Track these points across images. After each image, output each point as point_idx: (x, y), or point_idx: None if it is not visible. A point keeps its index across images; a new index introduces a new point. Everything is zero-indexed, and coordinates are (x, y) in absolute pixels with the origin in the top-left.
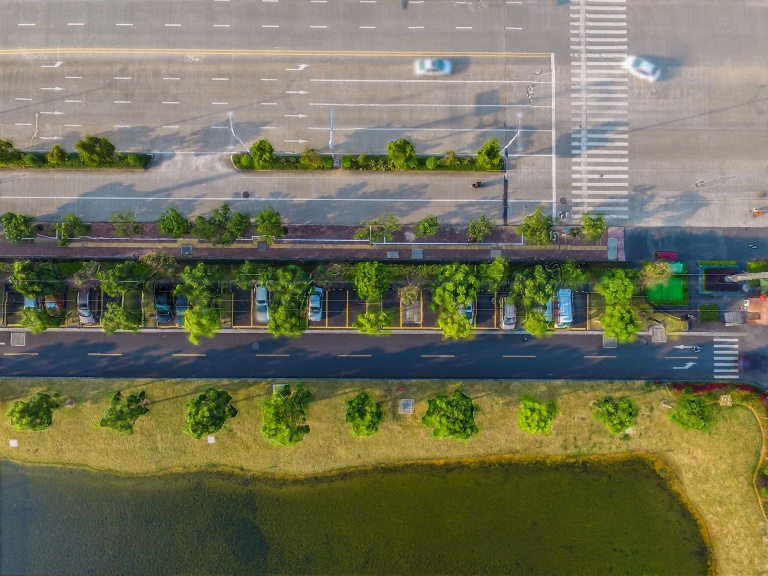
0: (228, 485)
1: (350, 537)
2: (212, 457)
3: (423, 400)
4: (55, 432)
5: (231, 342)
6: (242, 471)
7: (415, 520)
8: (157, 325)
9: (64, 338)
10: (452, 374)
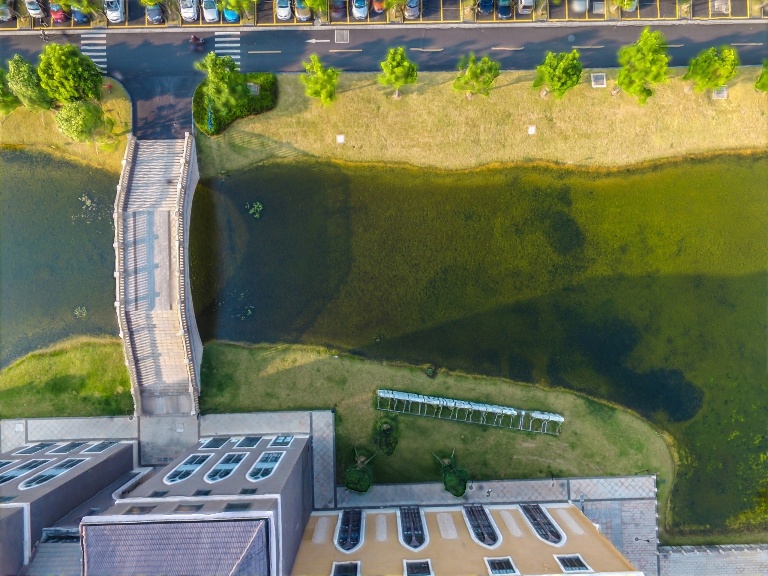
0: (543, 179)
1: (662, 227)
2: (530, 150)
3: (737, 84)
4: (381, 126)
5: (548, 35)
6: (557, 165)
7: (724, 209)
8: (475, 20)
9: (386, 34)
10: (762, 61)
